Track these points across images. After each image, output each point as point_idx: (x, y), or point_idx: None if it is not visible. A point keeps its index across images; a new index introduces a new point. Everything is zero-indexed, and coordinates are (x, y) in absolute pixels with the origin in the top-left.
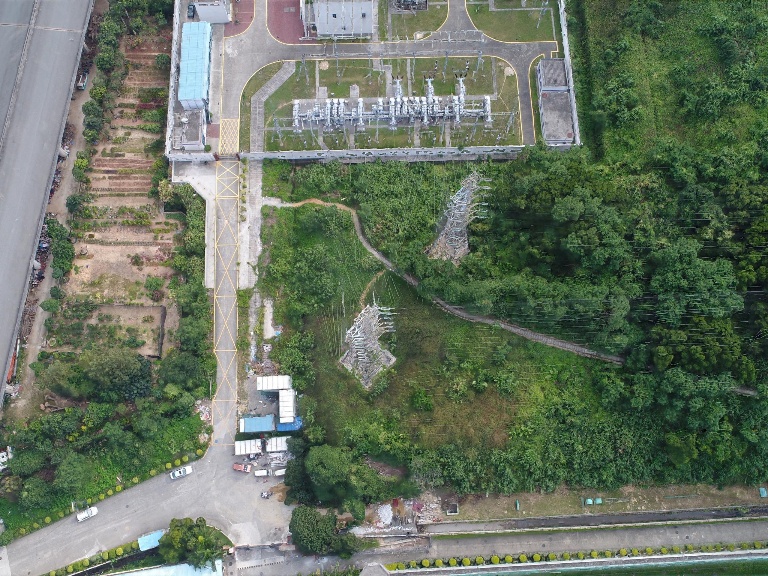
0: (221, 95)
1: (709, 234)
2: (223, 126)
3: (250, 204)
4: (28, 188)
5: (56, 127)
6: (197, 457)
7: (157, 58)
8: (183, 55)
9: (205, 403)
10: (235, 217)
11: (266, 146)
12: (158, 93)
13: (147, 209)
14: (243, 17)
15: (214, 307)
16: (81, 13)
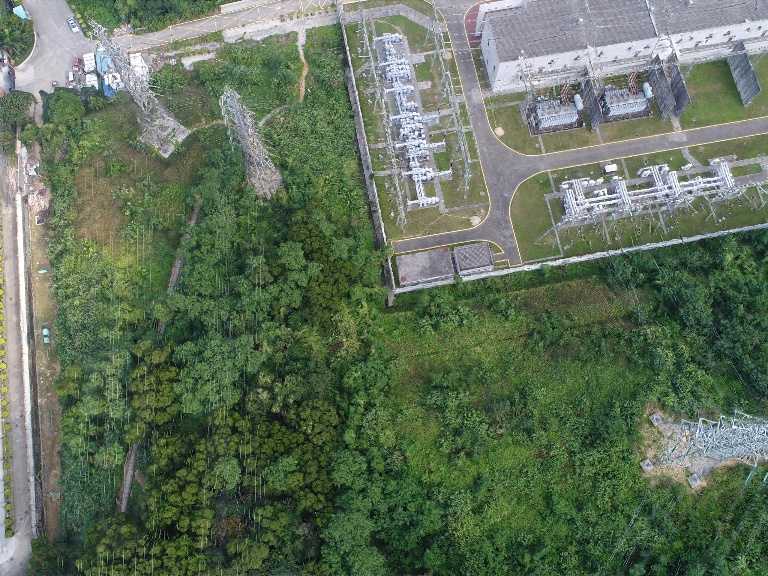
0: None
1: (264, 378)
2: None
3: (298, 22)
4: None
5: None
6: (86, 33)
7: None
8: None
9: (129, 30)
10: (284, 13)
11: None
12: None
13: None
14: None
15: (206, 17)
16: None
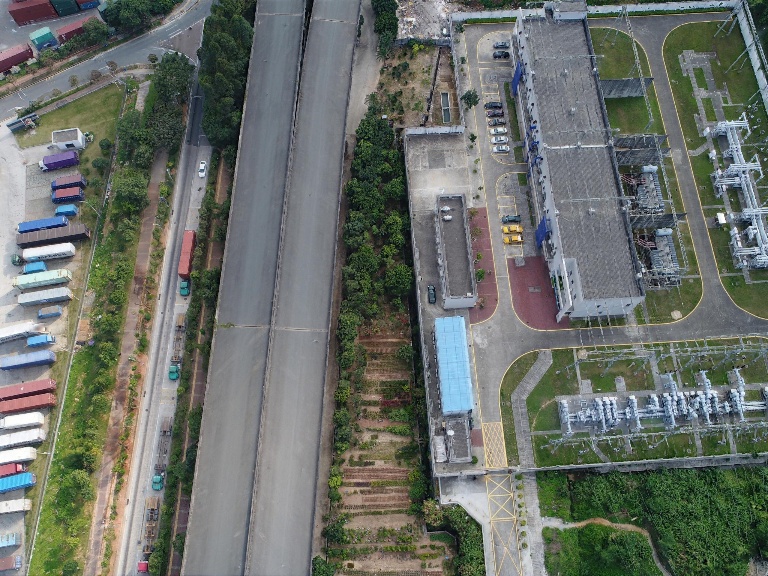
0: (478, 394)
1: None
2: (485, 431)
3: (529, 526)
4: (291, 525)
5: (312, 448)
6: None
7: (402, 351)
8: (441, 357)
9: None
10: (514, 543)
11: (536, 454)
12: (402, 387)
13: (408, 529)
14: (487, 300)
15: None
16: (322, 309)
